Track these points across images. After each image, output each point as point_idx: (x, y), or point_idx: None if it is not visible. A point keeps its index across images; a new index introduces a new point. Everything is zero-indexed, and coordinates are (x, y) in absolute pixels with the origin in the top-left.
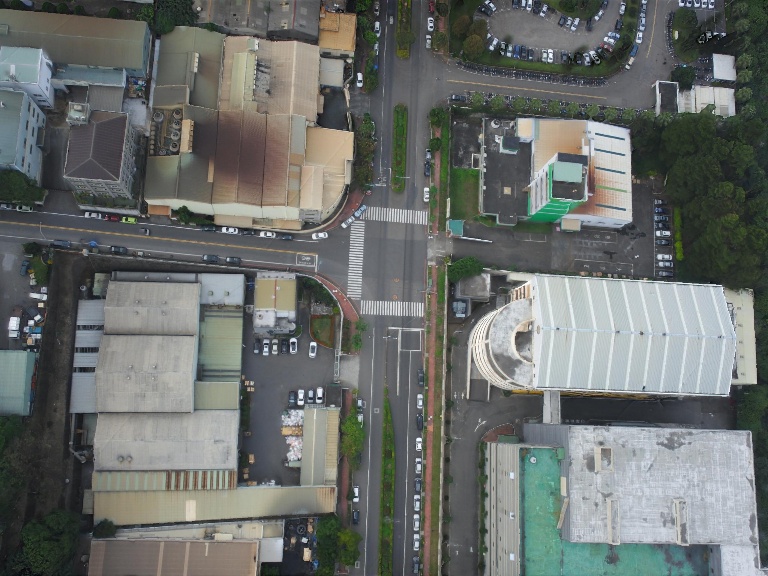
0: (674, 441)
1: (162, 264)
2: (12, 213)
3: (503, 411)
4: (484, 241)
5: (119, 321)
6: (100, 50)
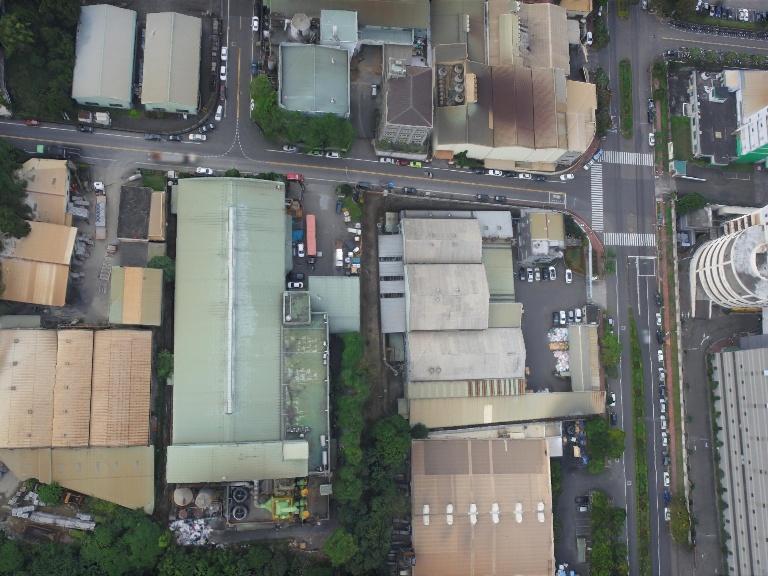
0: None
1: (444, 203)
2: (323, 159)
3: (722, 327)
4: (699, 180)
5: (417, 252)
6: (394, 13)
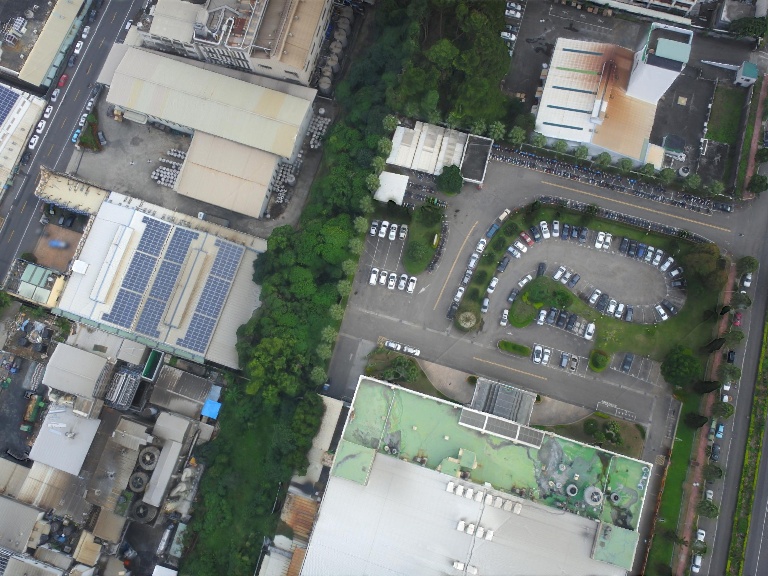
0: None
1: None
2: None
3: None
4: (710, 63)
5: None
6: None
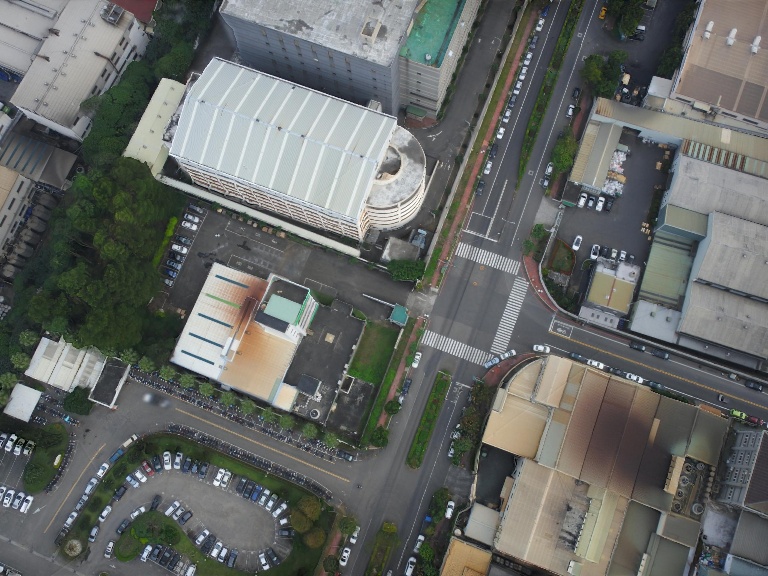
0: (296, 26)
1: None
2: None
3: None
4: (371, 297)
5: (765, 316)
6: None
